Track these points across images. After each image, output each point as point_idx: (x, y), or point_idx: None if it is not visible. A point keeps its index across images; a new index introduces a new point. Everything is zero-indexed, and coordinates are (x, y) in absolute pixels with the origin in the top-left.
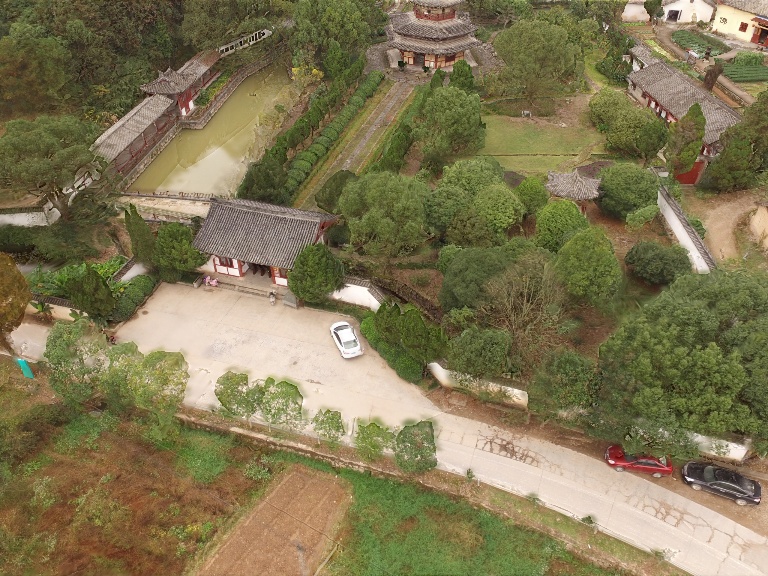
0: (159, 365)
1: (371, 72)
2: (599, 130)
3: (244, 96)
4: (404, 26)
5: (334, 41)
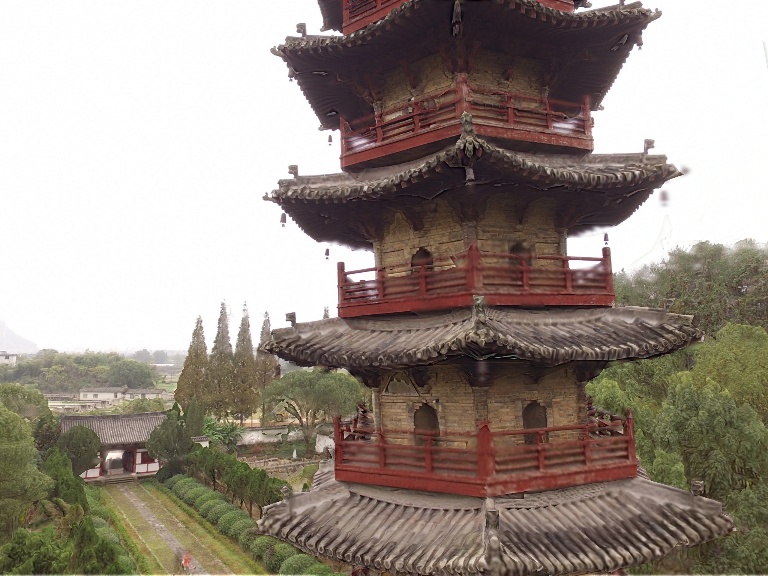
0: None
1: None
2: None
3: None
4: None
5: None
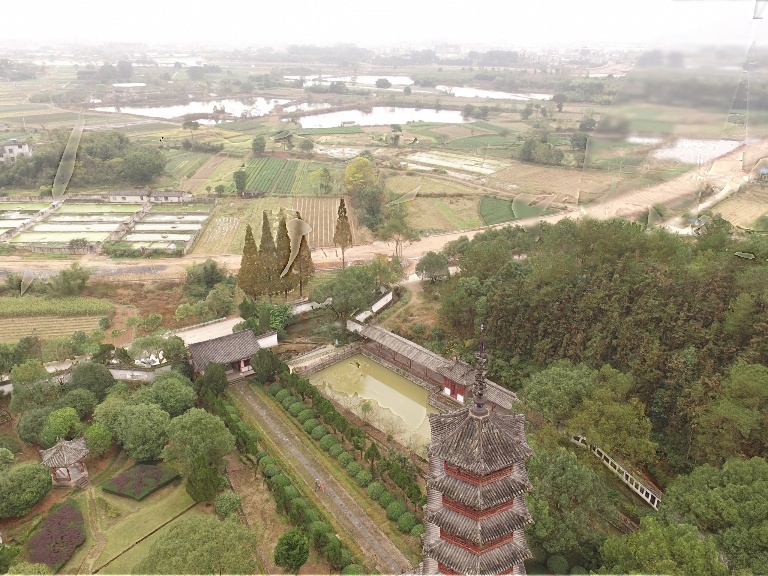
0: (182, 305)
1: None
2: None
3: None
4: None
5: None
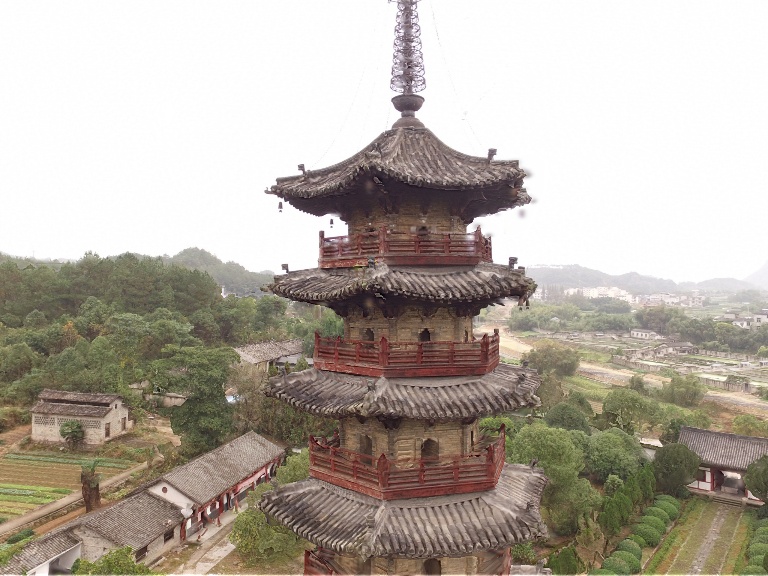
0: None
1: None
2: None
3: None
4: None
5: None
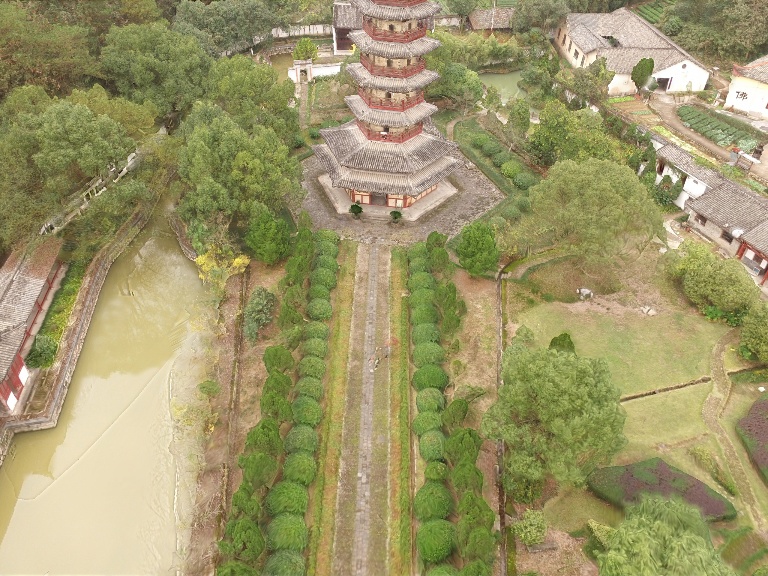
0: None
1: (318, 235)
2: (708, 318)
3: (112, 297)
4: (353, 155)
5: (258, 205)
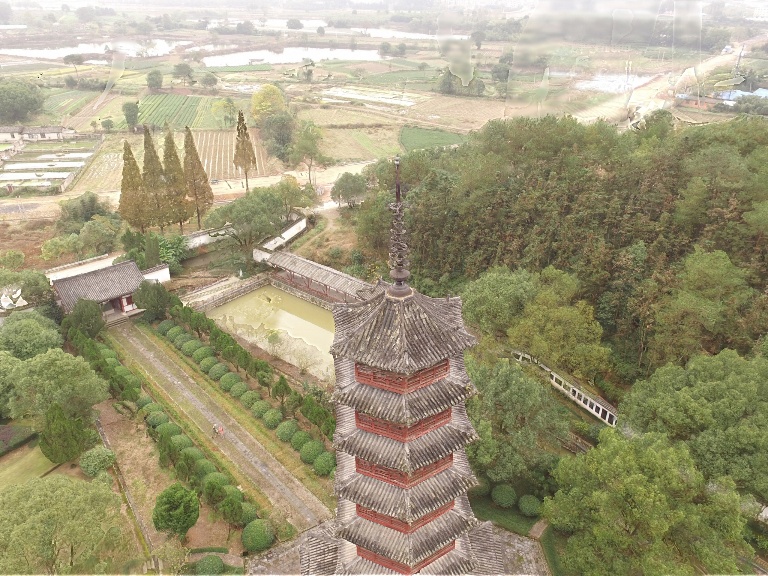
0: None
1: None
2: None
3: None
4: None
5: None
